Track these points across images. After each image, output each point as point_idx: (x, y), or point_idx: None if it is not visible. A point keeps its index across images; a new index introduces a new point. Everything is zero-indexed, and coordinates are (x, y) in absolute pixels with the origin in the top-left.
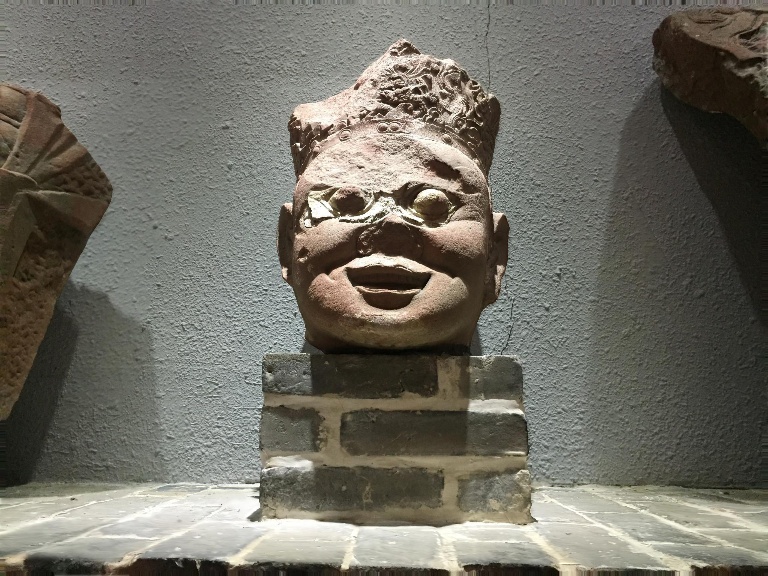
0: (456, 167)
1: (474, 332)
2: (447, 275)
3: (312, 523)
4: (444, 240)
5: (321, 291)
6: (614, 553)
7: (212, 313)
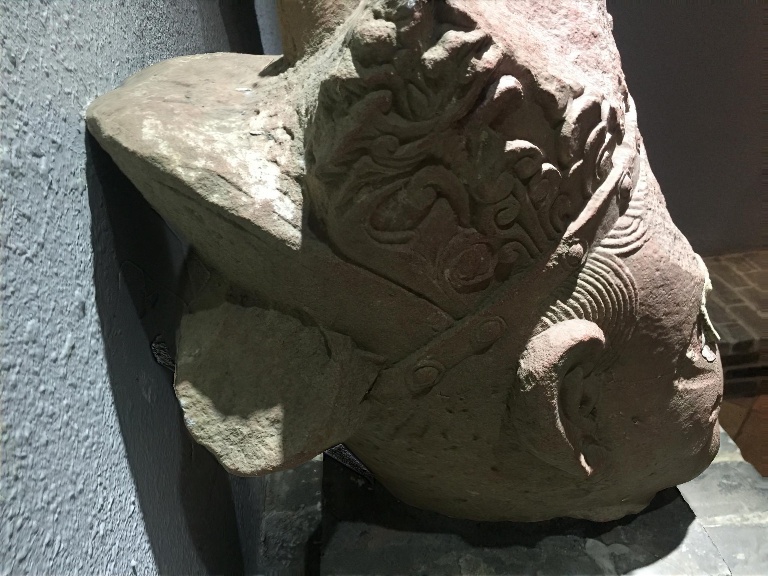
0: None
1: None
2: None
3: None
4: None
5: None
6: None
7: None
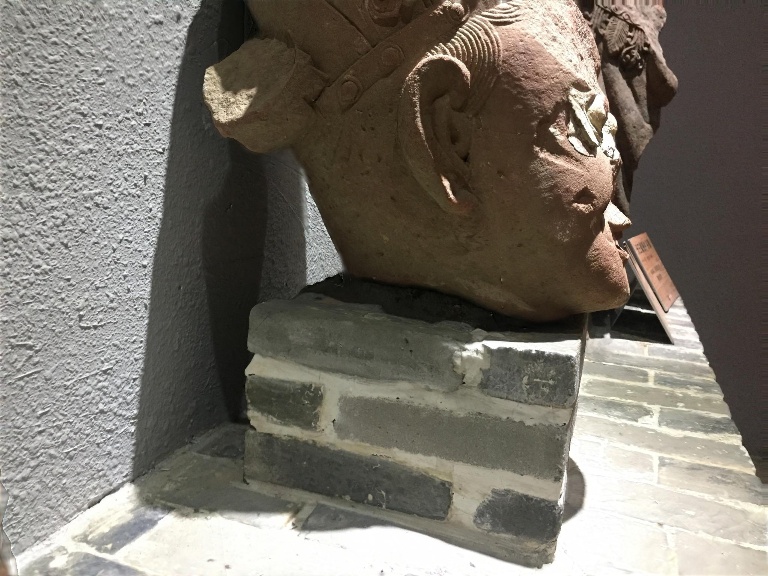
0: None
1: None
2: None
3: (570, 530)
4: None
5: (608, 259)
6: (707, 446)
7: (2, 180)
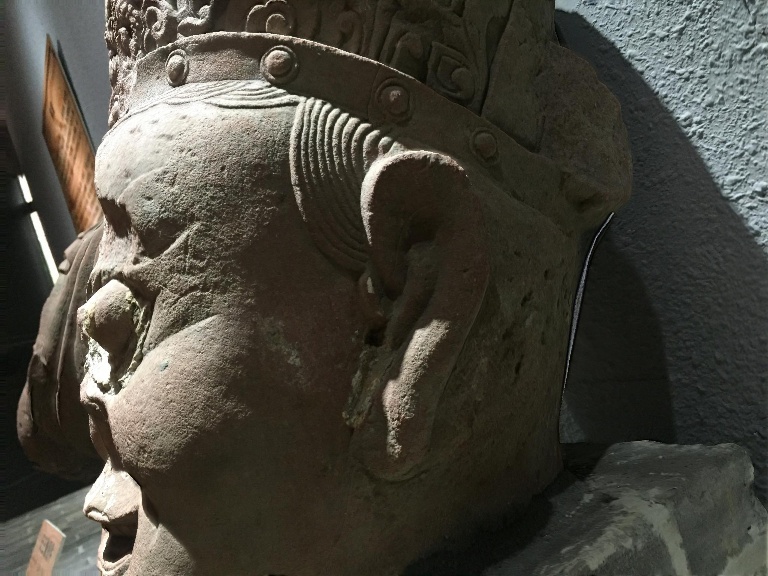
0: (121, 194)
1: (764, 276)
2: (148, 520)
3: None
4: (116, 434)
5: None
6: None
7: None
